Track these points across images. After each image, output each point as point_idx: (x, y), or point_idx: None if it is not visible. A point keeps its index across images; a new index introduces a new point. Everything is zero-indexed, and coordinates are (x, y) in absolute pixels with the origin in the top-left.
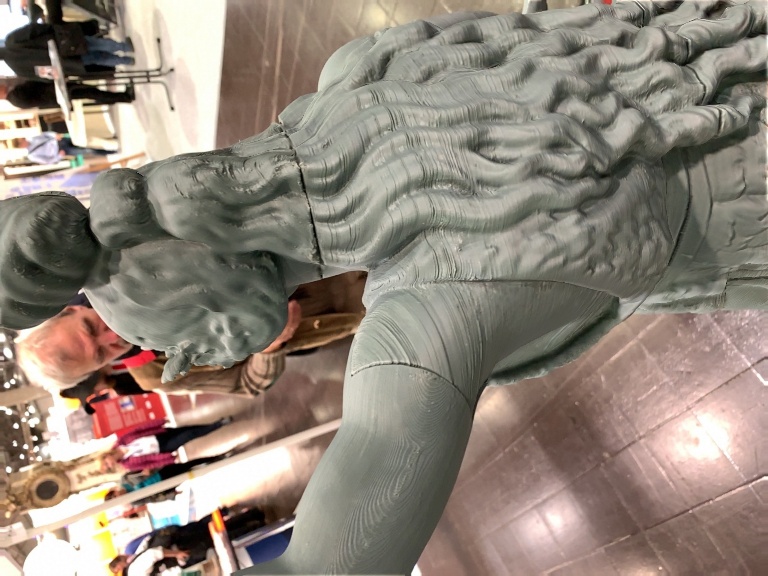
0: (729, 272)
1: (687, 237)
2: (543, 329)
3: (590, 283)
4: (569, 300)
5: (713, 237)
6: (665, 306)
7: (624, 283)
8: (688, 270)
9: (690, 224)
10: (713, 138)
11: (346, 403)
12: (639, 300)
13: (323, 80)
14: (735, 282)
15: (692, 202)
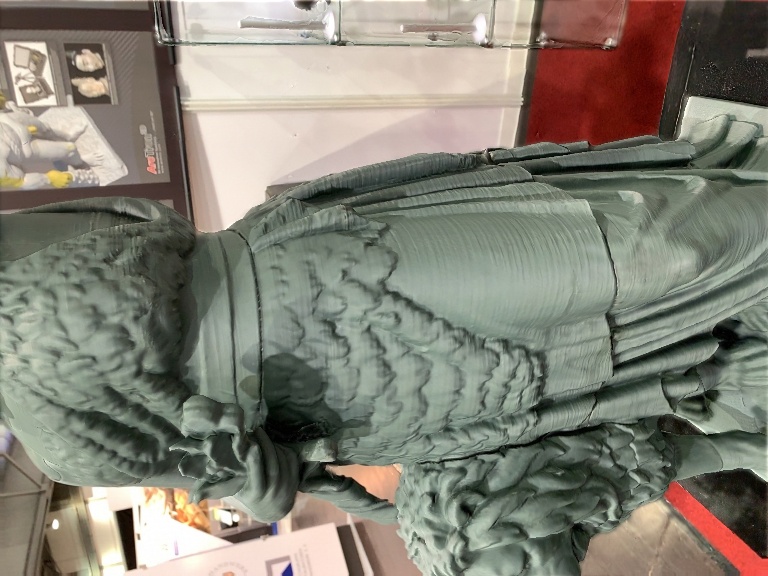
0: None
1: None
2: None
3: None
4: None
5: None
6: None
7: None
8: None
9: None
10: None
11: None
12: (150, 206)
13: None
14: None
15: None
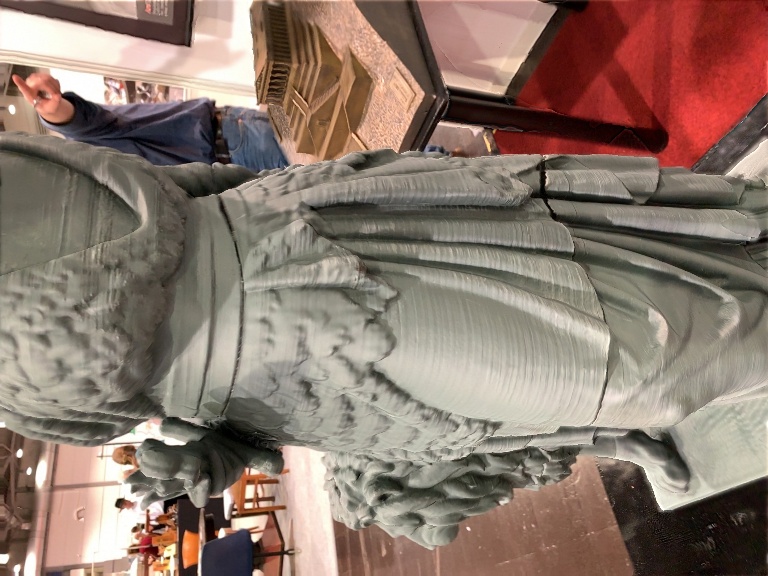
0: (307, 220)
1: (230, 208)
2: (4, 184)
3: (26, 139)
4: (25, 165)
5: (250, 197)
6: (274, 270)
7: (71, 146)
8: (253, 225)
9: (227, 202)
10: (215, 174)
11: None
12: (137, 189)
13: None
14: (383, 264)
15: (222, 196)
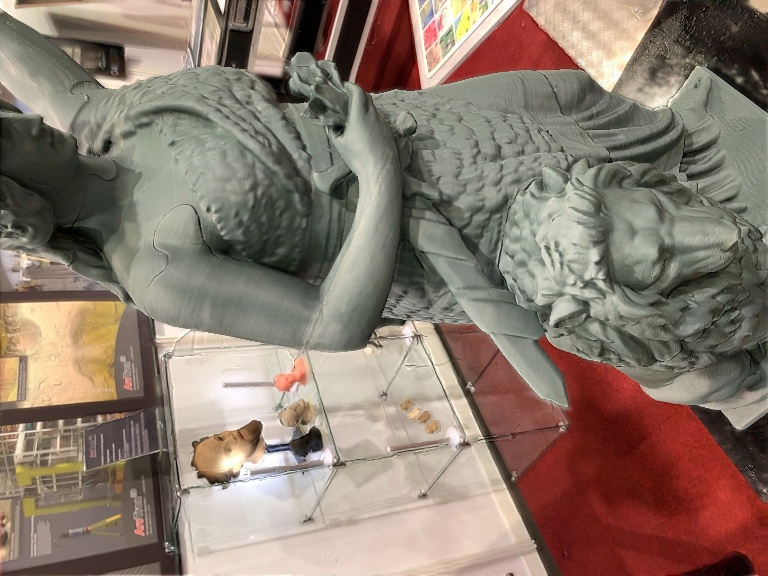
0: None
1: None
2: None
3: None
4: None
5: None
6: None
7: None
8: None
9: None
10: None
11: (41, 114)
12: None
13: (131, 296)
14: None
15: None
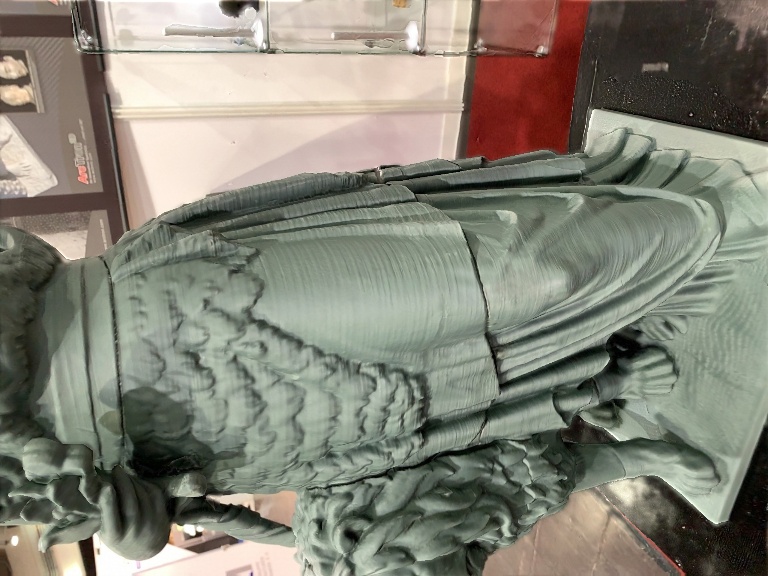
0: None
1: None
2: None
3: None
4: None
5: None
6: None
7: None
8: None
9: None
10: None
11: None
12: (7, 235)
13: None
14: None
15: None
